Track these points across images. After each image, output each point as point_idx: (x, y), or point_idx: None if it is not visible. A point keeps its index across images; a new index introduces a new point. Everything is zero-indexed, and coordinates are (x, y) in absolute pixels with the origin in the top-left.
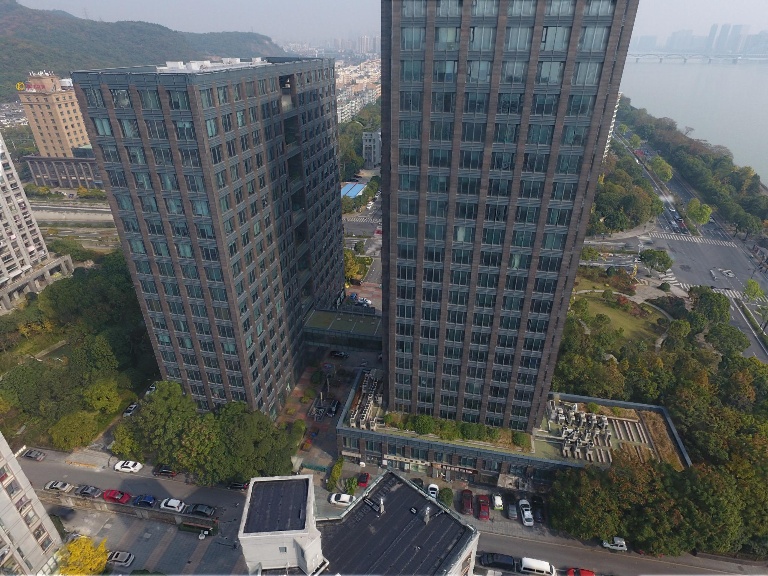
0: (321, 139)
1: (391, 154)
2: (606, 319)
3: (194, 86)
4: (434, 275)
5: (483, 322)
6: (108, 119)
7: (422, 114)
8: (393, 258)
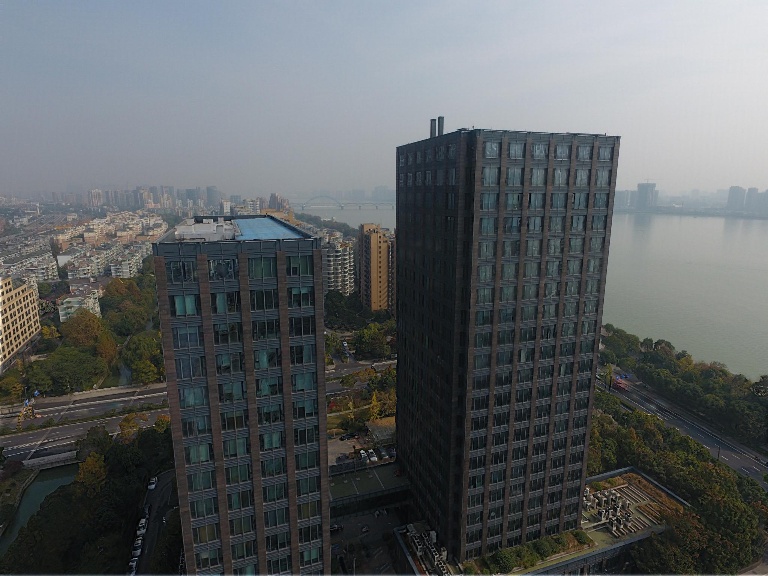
0: None
1: (471, 295)
2: None
3: None
4: (503, 399)
5: (541, 432)
6: (196, 295)
7: (496, 259)
8: (469, 392)
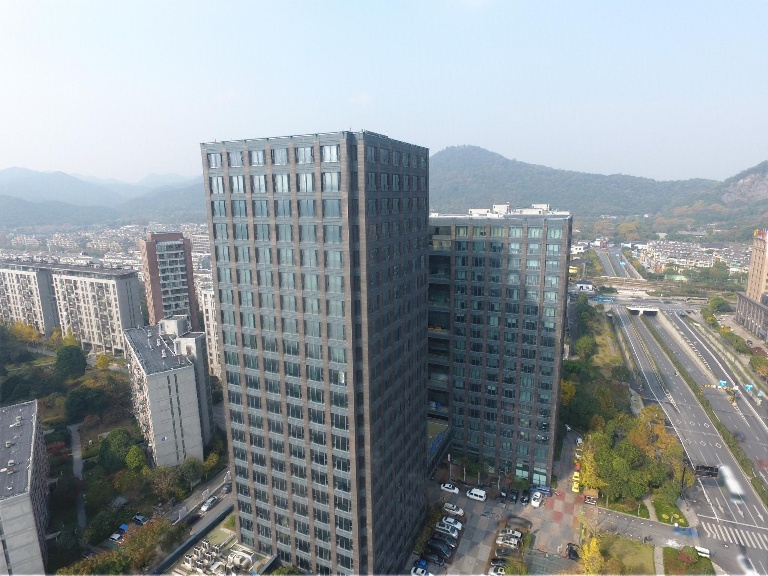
0: (504, 288)
1: None
2: None
3: None
4: None
5: None
6: None
7: None
8: None
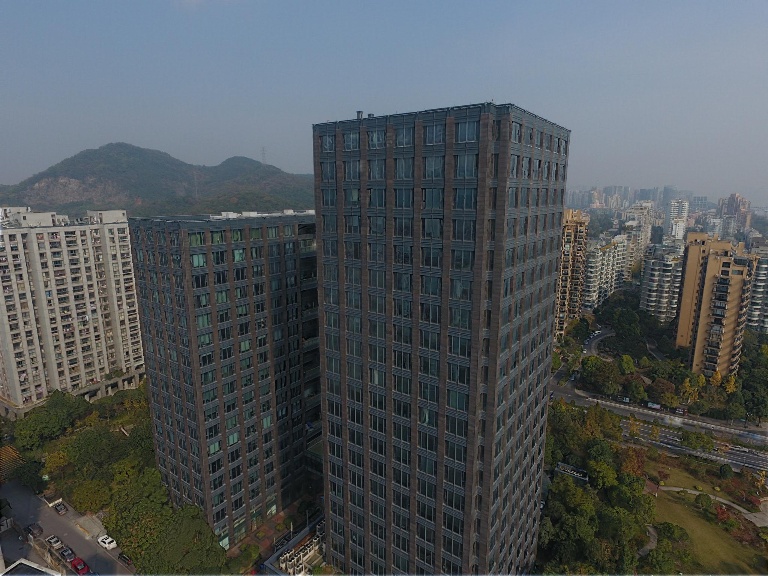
0: None
1: None
2: (675, 532)
3: (182, 230)
4: (356, 416)
5: (402, 480)
6: (142, 250)
7: (338, 259)
8: (323, 391)
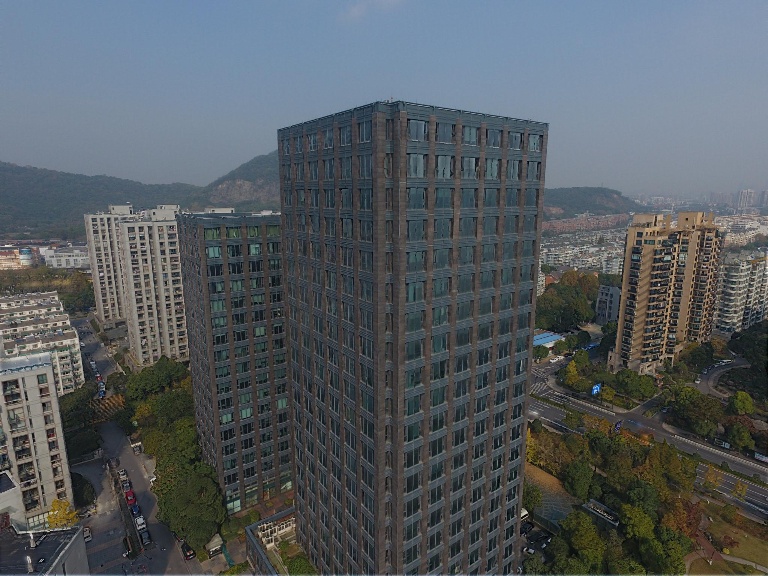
0: None
1: None
2: None
3: (198, 225)
4: (309, 406)
5: (337, 474)
6: None
7: (294, 256)
8: (290, 378)
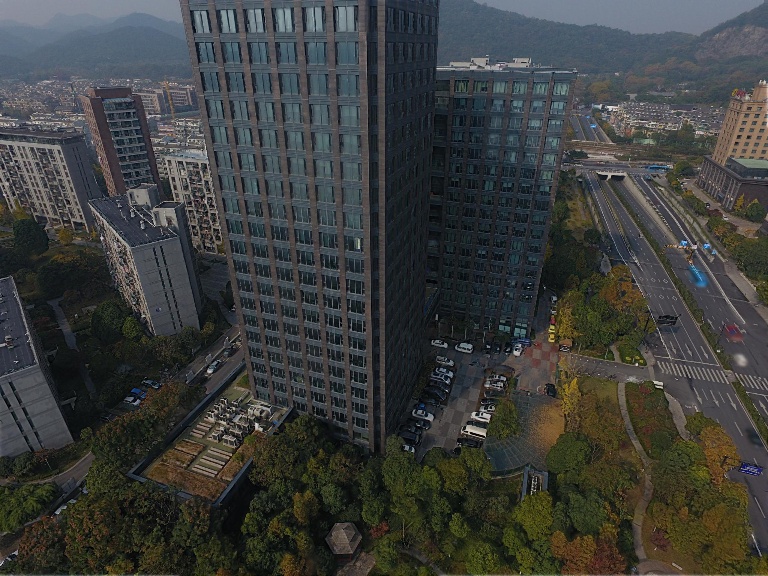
0: (502, 150)
1: None
2: None
3: None
4: None
5: None
6: None
7: None
8: None
